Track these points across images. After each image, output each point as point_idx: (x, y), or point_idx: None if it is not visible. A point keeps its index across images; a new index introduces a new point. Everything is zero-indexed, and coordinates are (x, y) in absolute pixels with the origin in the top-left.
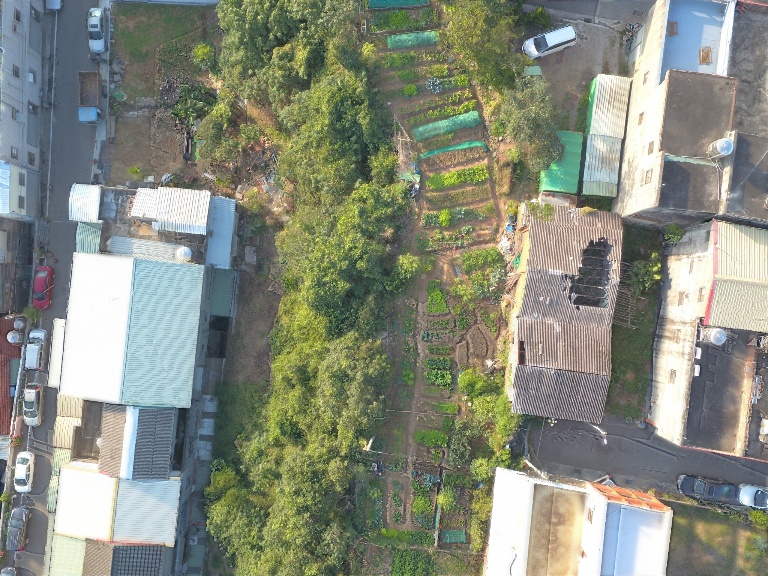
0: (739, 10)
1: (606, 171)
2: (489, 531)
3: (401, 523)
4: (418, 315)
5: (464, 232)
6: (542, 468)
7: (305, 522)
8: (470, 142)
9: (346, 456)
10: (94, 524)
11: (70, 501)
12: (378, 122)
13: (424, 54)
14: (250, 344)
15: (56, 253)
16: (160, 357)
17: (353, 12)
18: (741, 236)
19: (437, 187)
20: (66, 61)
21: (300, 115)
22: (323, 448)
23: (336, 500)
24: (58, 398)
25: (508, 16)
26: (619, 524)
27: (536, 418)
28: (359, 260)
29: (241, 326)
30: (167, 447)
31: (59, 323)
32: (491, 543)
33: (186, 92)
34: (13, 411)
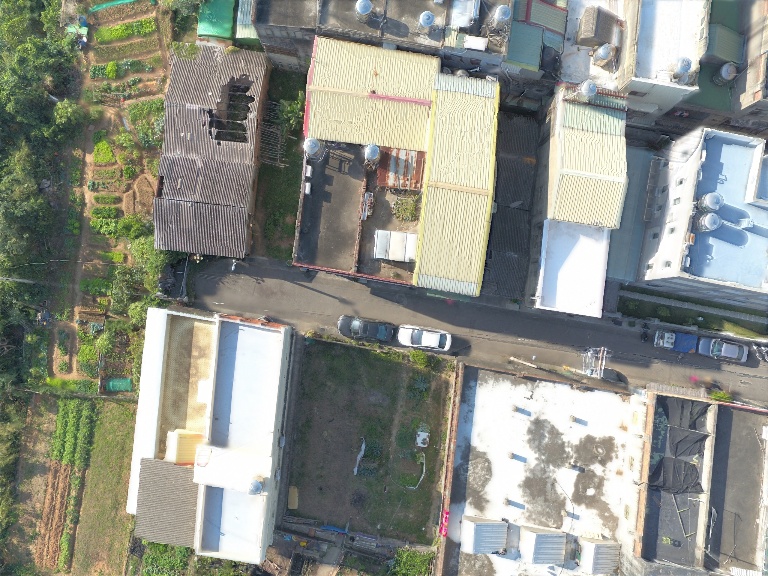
0: None
1: None
2: None
3: (67, 372)
4: (85, 166)
5: (131, 83)
6: None
7: None
8: None
9: (4, 303)
10: None
11: None
12: None
13: None
14: None
15: None
16: None
17: None
18: (340, 50)
19: (105, 39)
20: None
21: None
22: None
23: None
24: None
25: None
26: (237, 345)
27: (192, 260)
28: (9, 103)
29: None
30: None
31: None
32: (141, 383)
33: None
34: None
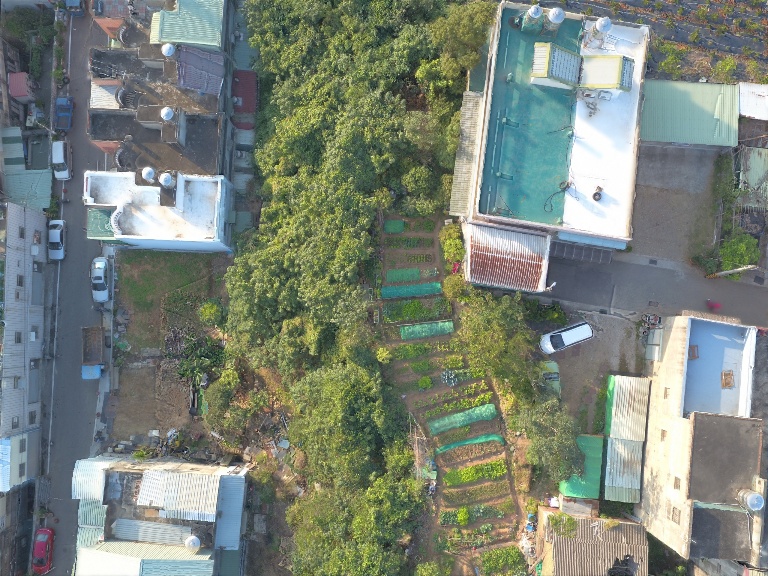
0: (760, 335)
1: (628, 476)
2: None
3: None
4: None
5: (483, 531)
6: None
7: None
8: (487, 435)
9: None
10: None
11: None
12: (393, 416)
13: (438, 345)
14: None
15: (57, 512)
16: None
17: (366, 313)
18: None
19: (454, 484)
20: (69, 311)
21: (311, 397)
22: None
23: None
24: None
25: (525, 331)
26: None
27: None
28: None
29: None
30: None
31: None
32: None
33: (192, 345)
34: None
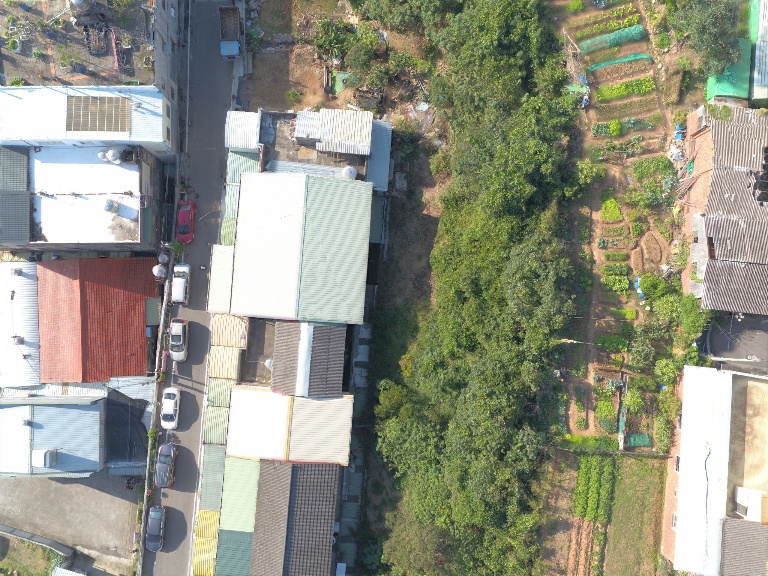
0: None
1: None
2: (674, 432)
3: (584, 429)
4: (592, 223)
5: (634, 141)
6: (749, 352)
7: (499, 424)
8: (635, 54)
9: (532, 361)
10: (269, 444)
11: (242, 422)
12: (546, 36)
13: None
14: (407, 267)
15: (197, 188)
16: (333, 273)
17: None
18: None
19: (606, 98)
20: None
21: (460, 35)
22: (510, 353)
23: (524, 405)
24: (213, 327)
25: None
26: None
27: (718, 317)
28: (543, 164)
29: (394, 251)
30: (340, 364)
31: (218, 249)
32: (683, 440)
33: (325, 26)
34: (158, 346)
